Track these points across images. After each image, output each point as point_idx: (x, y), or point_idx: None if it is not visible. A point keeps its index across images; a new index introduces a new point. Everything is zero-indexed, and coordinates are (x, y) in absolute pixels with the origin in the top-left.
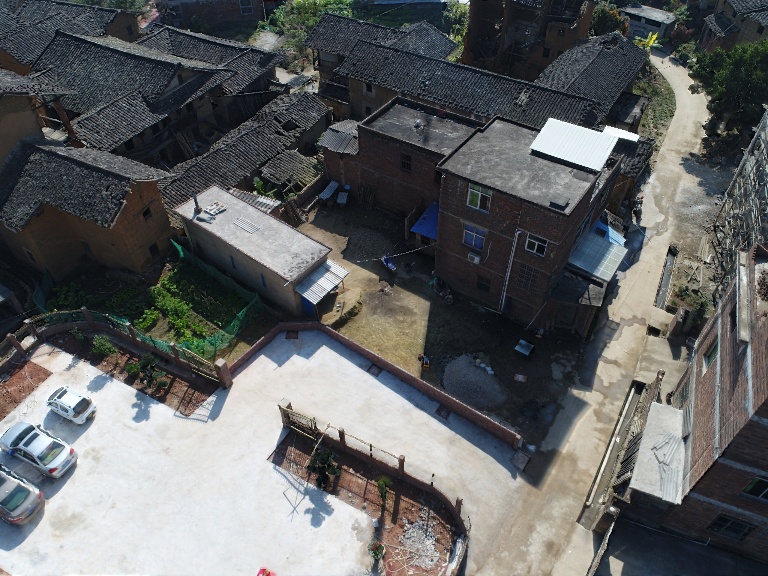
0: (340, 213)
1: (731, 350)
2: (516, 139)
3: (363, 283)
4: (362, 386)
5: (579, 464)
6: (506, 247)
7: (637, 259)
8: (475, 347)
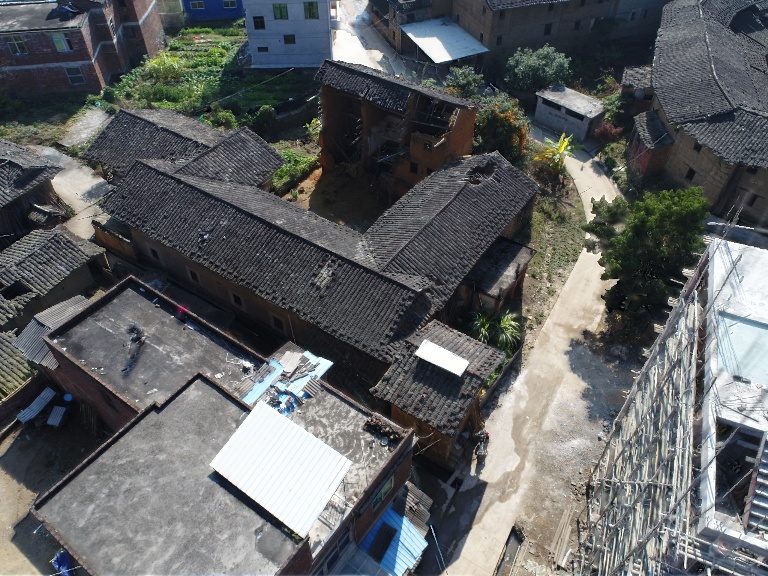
0: (49, 440)
1: None
2: (205, 432)
3: None
4: None
5: None
6: None
7: (457, 554)
8: None
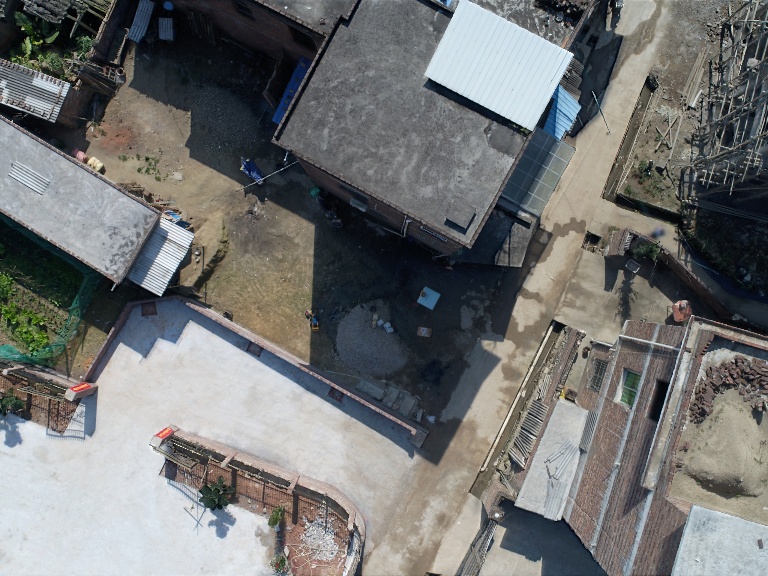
0: (170, 57)
1: (640, 447)
2: (404, 41)
3: (224, 201)
4: (244, 372)
5: (478, 433)
6: (397, 214)
7: (596, 109)
8: (372, 292)
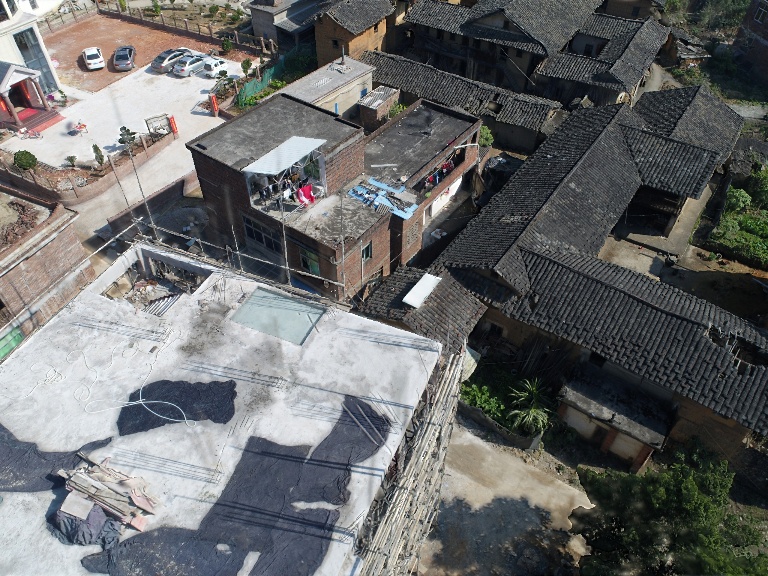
0: None
1: None
2: (318, 136)
3: None
4: (193, 165)
5: None
6: None
7: None
8: None
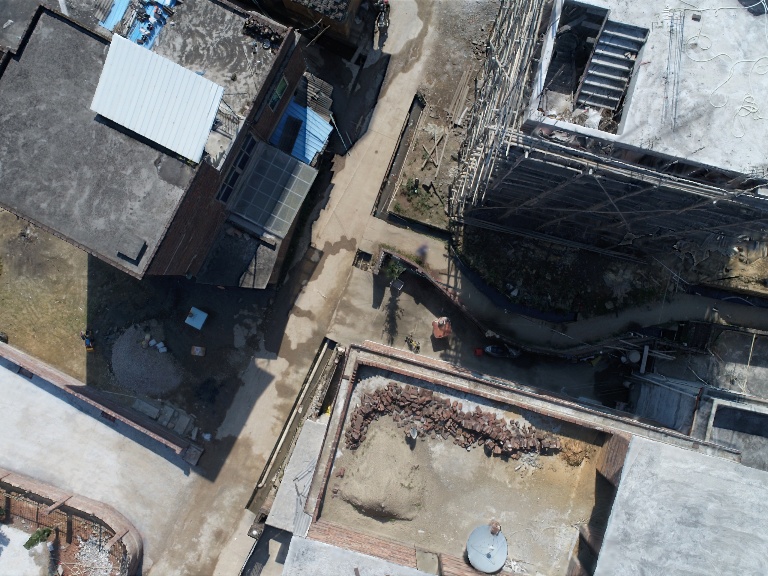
0: None
1: None
2: (74, 74)
3: None
4: (16, 394)
5: (253, 449)
6: None
7: (365, 128)
8: (146, 312)
